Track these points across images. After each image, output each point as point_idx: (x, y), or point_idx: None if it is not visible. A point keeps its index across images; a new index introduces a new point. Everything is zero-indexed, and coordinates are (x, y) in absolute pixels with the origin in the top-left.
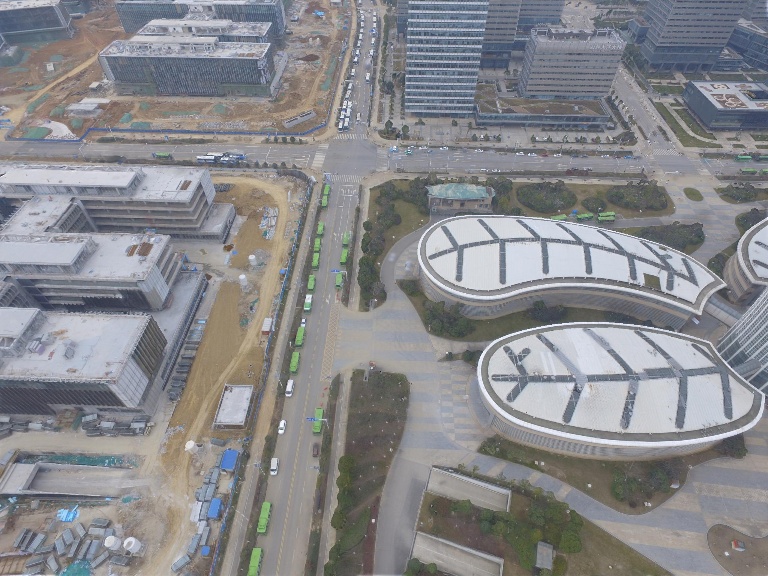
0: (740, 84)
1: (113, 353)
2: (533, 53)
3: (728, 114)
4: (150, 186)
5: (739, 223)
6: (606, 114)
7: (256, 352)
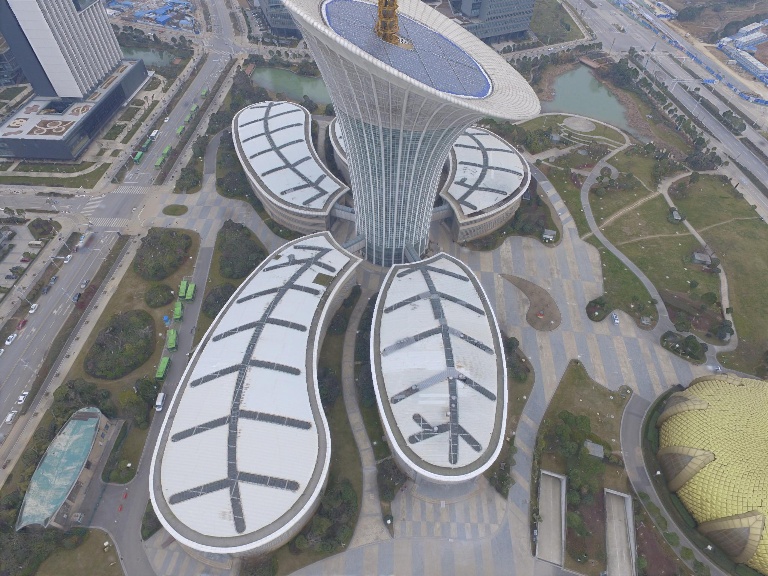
0: (25, 109)
1: None
2: None
3: (71, 138)
4: None
5: (231, 196)
6: None
7: None
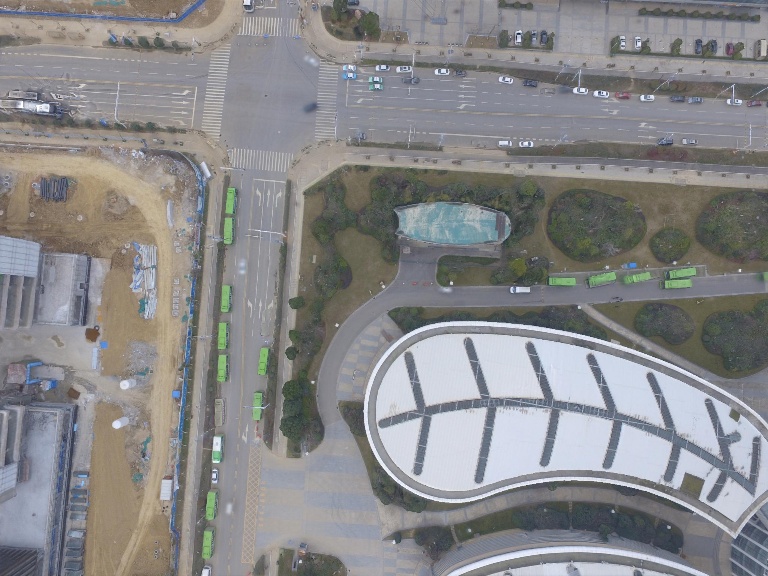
0: None
1: None
2: None
3: None
4: None
5: None
6: None
7: (159, 526)
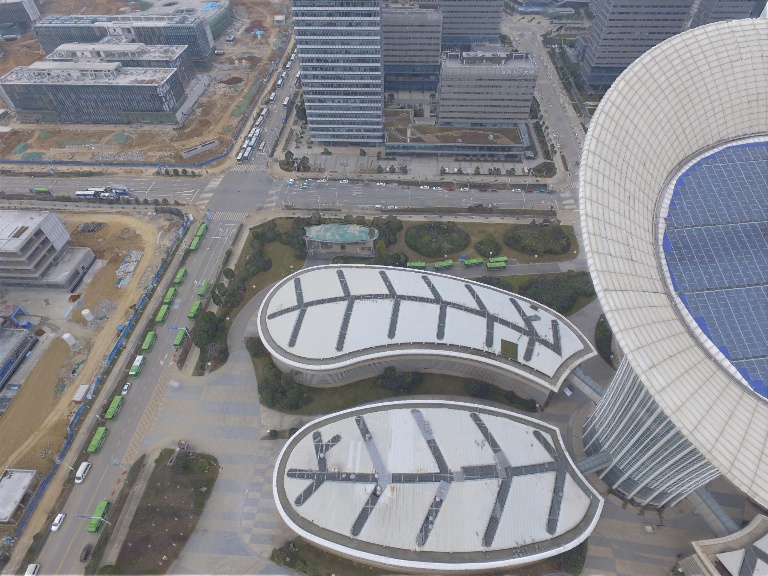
0: None
1: None
2: (441, 79)
3: None
4: None
5: None
6: (522, 143)
7: (60, 426)
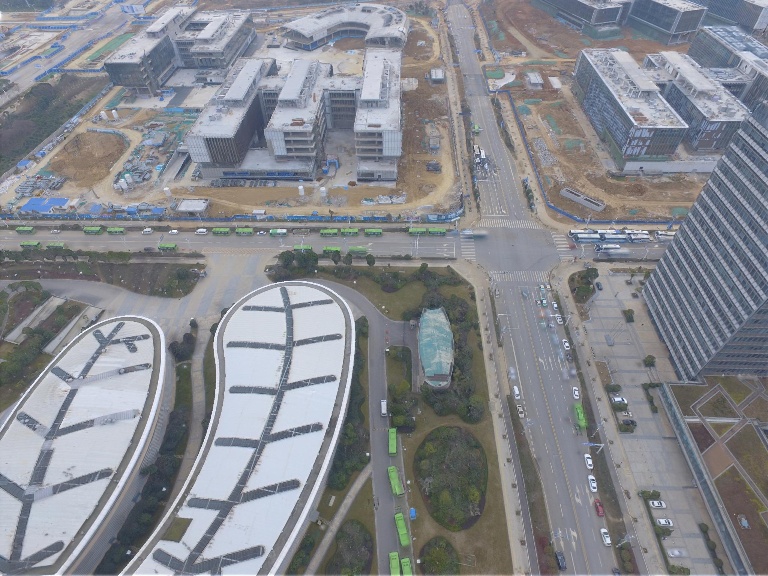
0: None
1: (207, 132)
2: None
3: None
4: (373, 112)
5: None
6: None
7: (238, 212)
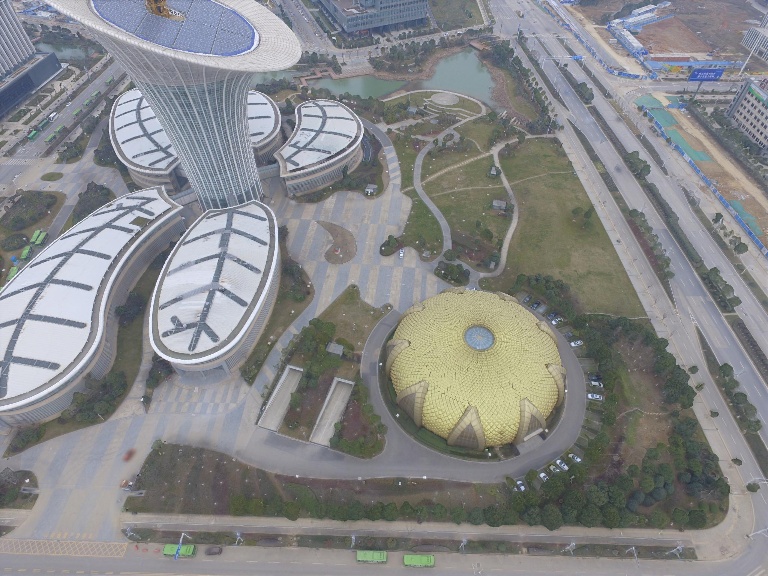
0: None
1: None
2: None
3: None
4: None
5: (103, 164)
6: None
7: None
